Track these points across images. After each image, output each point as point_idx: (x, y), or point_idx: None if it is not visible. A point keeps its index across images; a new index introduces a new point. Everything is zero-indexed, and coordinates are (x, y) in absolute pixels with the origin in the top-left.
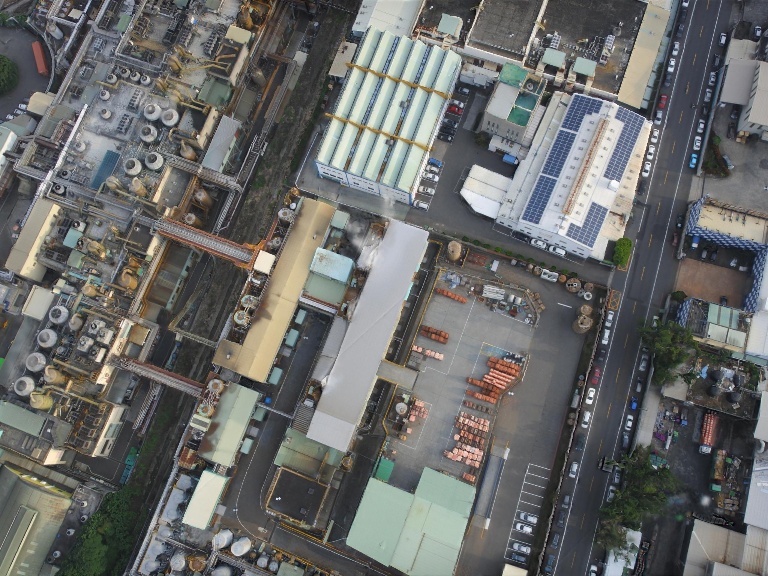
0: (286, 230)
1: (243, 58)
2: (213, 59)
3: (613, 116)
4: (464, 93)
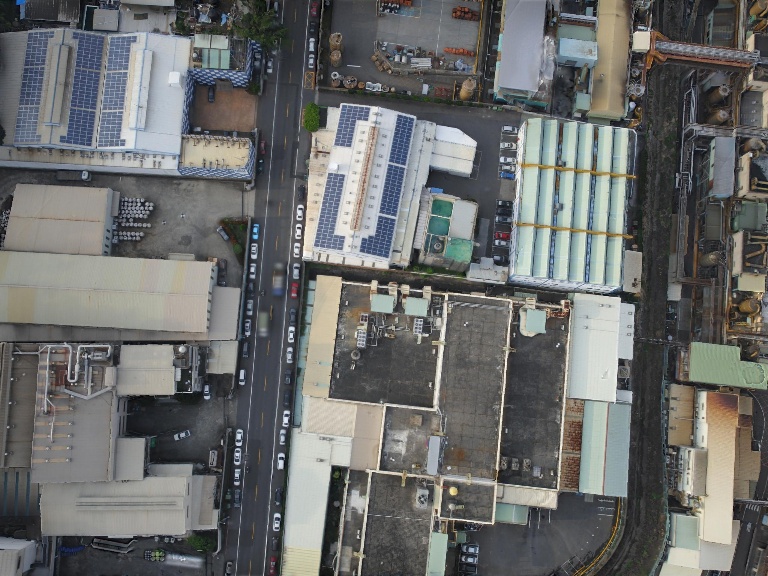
0: (631, 83)
1: (736, 264)
2: (767, 249)
3: (347, 238)
4: (498, 256)
